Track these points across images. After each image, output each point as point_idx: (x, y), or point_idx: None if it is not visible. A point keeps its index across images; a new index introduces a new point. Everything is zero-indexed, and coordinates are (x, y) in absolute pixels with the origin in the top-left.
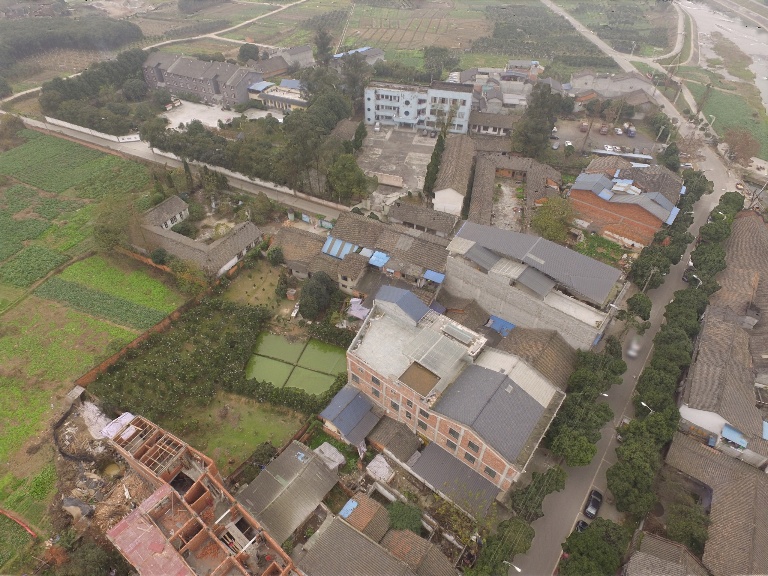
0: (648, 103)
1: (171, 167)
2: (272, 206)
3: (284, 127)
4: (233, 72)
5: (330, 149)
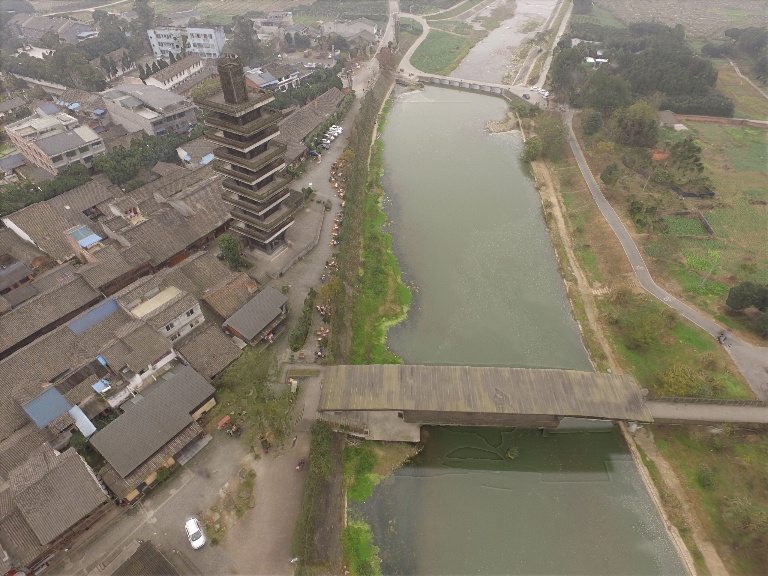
0: (359, 37)
1: None
2: (45, 94)
3: (41, 39)
4: (63, 23)
5: (67, 51)
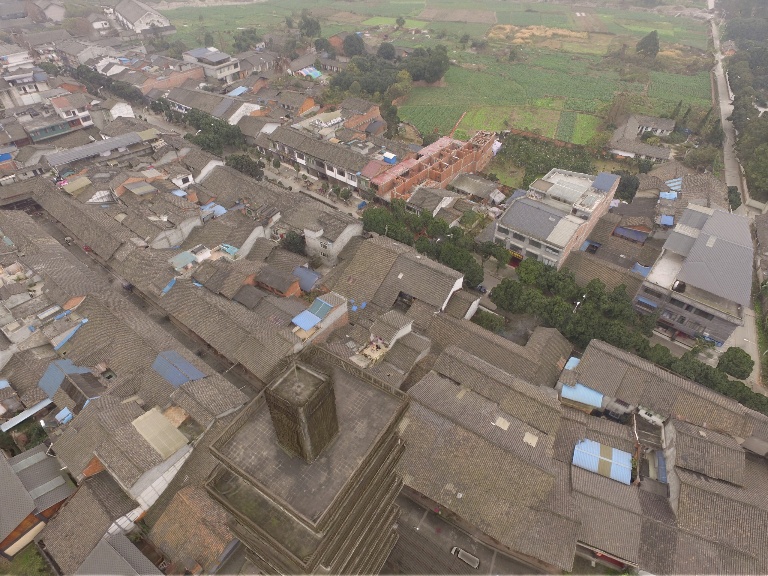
0: None
1: (721, 122)
2: (709, 162)
3: None
4: None
5: None
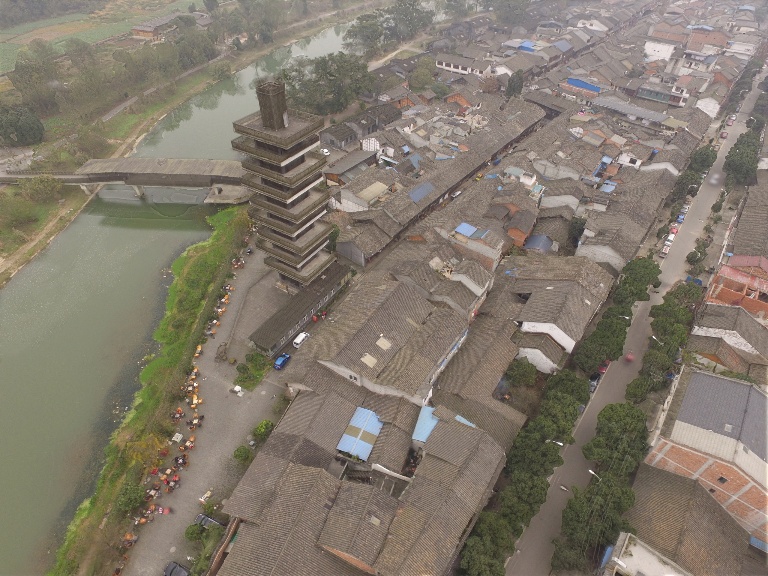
0: None
1: None
2: None
3: None
4: None
5: None
